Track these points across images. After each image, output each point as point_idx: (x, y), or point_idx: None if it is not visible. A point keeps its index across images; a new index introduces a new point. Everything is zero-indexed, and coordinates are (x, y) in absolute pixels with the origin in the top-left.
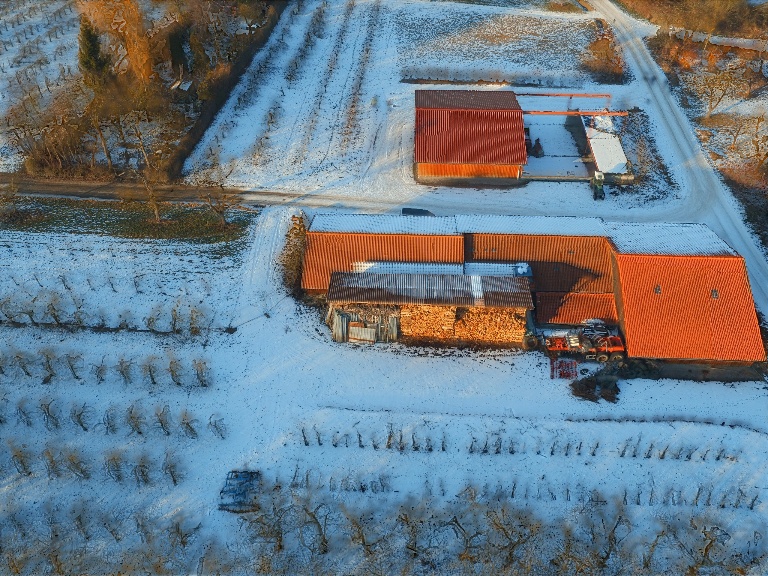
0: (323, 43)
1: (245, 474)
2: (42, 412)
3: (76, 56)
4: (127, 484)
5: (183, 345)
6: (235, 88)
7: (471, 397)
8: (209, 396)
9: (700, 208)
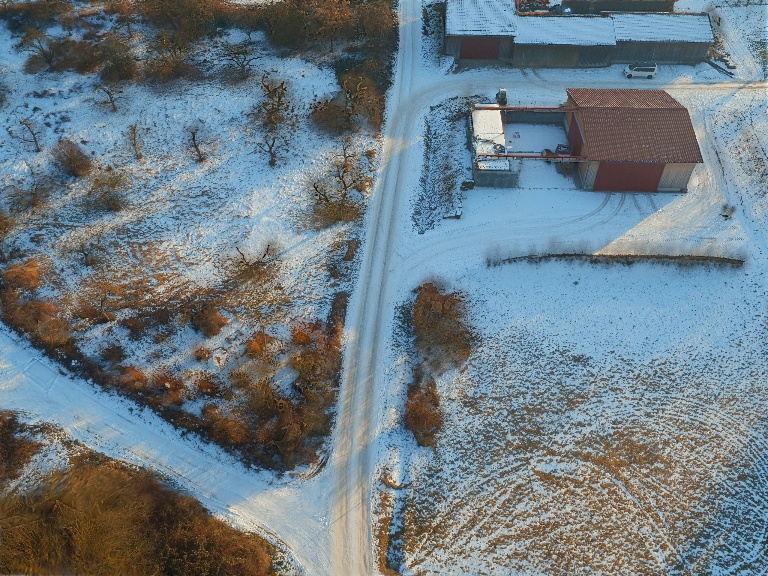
0: None
1: None
2: None
3: None
4: None
5: None
6: None
7: None
8: None
9: (419, 97)
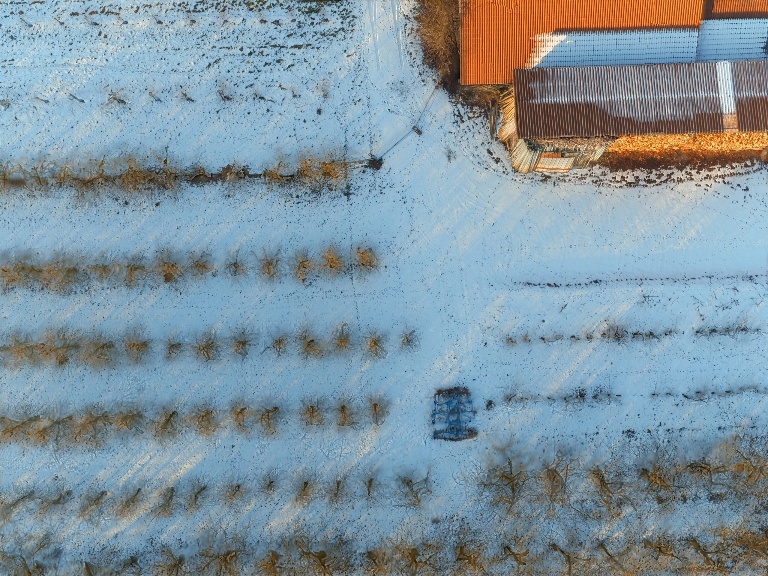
0: None
1: (453, 394)
2: (199, 350)
3: None
4: None
5: (319, 197)
6: None
7: (694, 248)
8: (377, 279)
9: None
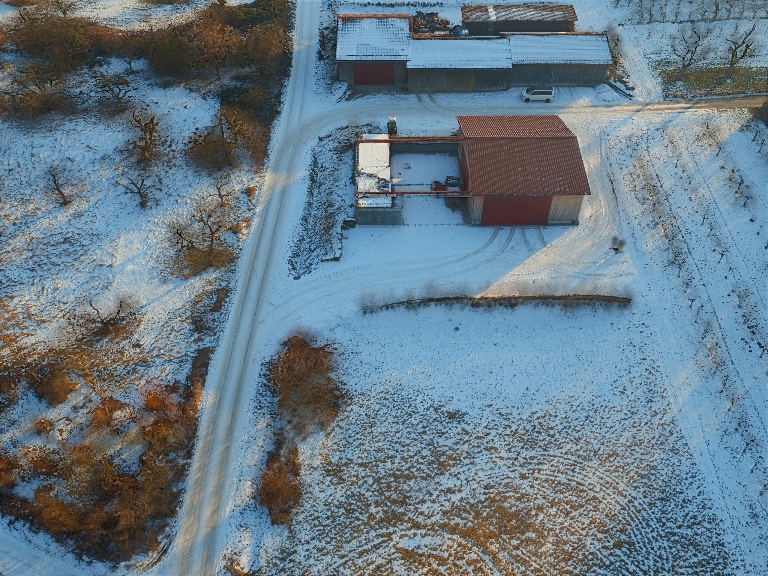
0: None
1: None
2: None
3: None
4: None
5: (640, 18)
6: None
7: None
8: None
9: (308, 127)
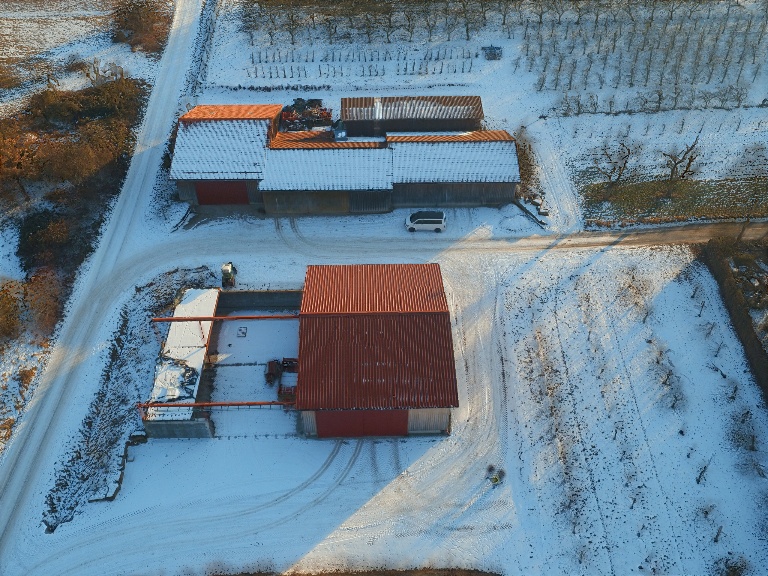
0: None
1: None
2: None
3: None
4: None
5: None
6: None
7: None
8: None
9: (125, 271)
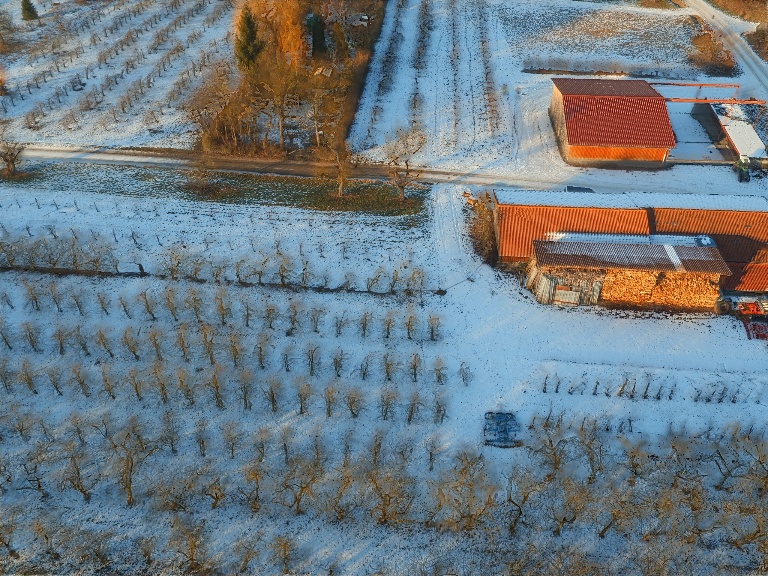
0: (435, 35)
1: (500, 415)
2: (307, 358)
3: (210, 44)
4: (394, 422)
5: (402, 305)
6: (368, 75)
7: (680, 354)
8: (441, 349)
9: None
